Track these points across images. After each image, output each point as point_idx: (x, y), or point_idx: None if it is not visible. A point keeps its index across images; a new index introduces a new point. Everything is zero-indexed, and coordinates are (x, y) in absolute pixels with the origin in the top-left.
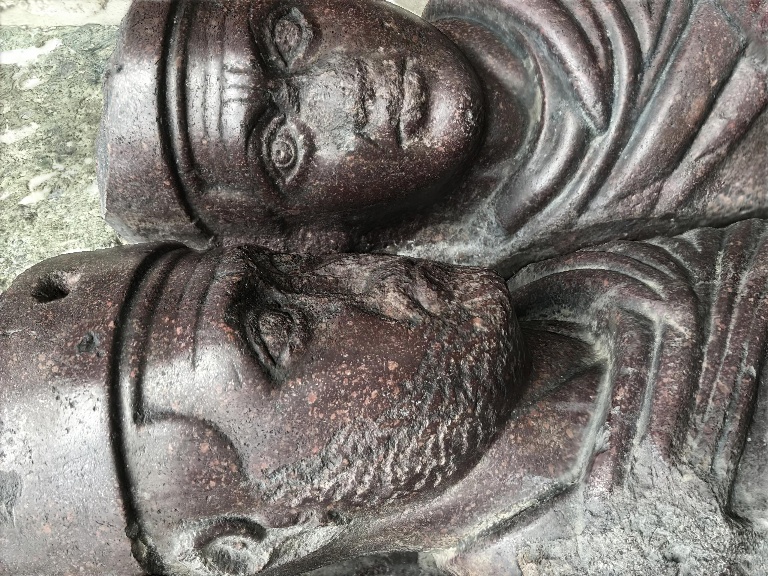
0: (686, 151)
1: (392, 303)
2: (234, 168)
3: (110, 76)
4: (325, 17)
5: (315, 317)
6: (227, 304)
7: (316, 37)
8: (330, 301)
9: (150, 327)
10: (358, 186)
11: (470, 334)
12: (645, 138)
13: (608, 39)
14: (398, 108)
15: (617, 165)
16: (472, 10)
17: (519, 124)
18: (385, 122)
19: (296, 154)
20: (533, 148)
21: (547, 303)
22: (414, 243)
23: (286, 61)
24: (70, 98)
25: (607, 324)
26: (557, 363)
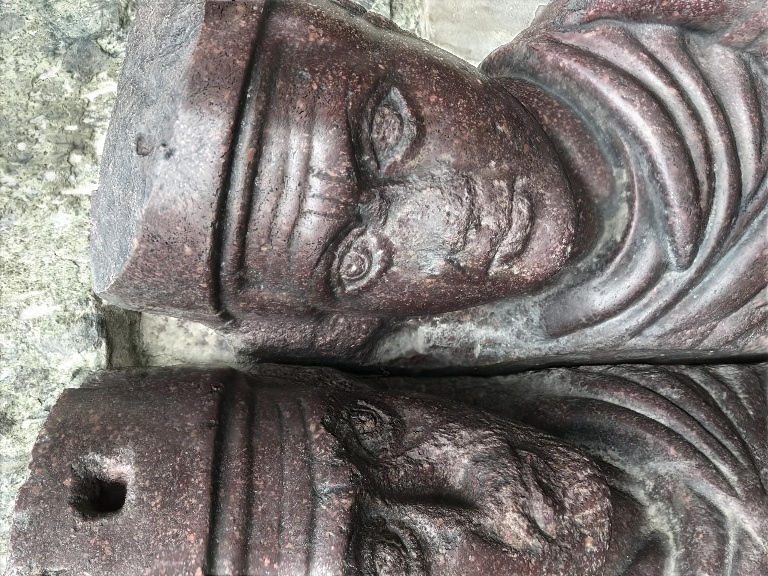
0: (751, 298)
1: (511, 526)
2: (291, 276)
3: (151, 158)
4: (430, 107)
5: (430, 544)
6: (344, 547)
7: (419, 135)
8: (446, 524)
9: (246, 572)
10: (427, 303)
11: (582, 557)
12: (721, 284)
13: (714, 174)
14: (501, 239)
15: (683, 301)
16: (564, 87)
17: (593, 235)
18: (483, 253)
19: (369, 268)
20: (604, 267)
21: (592, 437)
22: (440, 320)
23: (379, 161)
24: (17, 73)
25: (670, 497)
26: (623, 539)
